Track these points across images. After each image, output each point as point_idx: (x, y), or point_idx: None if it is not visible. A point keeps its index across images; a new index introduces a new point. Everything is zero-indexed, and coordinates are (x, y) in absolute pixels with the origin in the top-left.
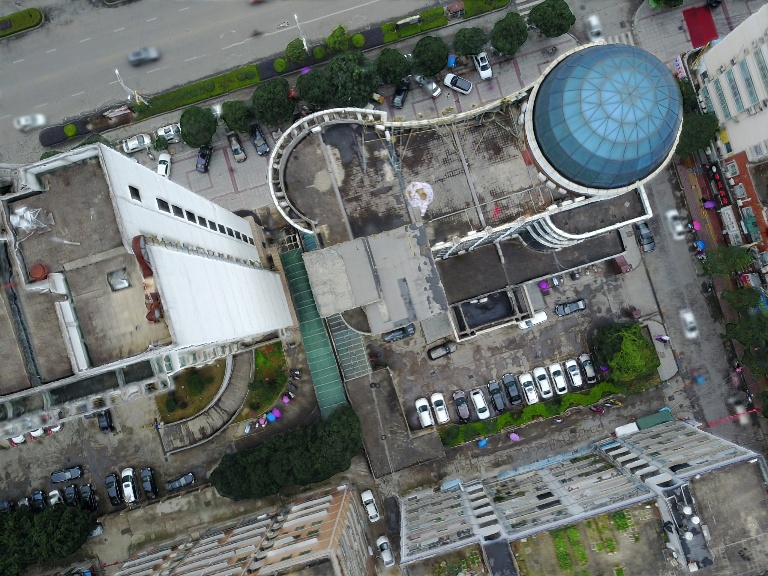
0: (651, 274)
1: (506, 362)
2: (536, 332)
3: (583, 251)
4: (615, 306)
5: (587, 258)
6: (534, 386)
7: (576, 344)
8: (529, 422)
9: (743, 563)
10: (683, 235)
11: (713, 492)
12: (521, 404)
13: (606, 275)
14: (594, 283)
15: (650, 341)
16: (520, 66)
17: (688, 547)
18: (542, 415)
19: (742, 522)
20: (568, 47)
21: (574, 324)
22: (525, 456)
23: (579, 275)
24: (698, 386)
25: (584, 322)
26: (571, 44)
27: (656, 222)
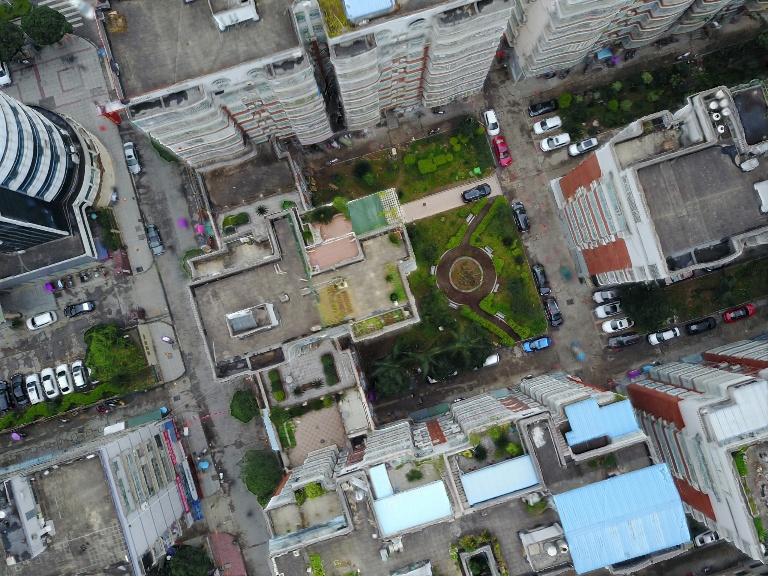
0: (163, 277)
1: (18, 363)
2: (48, 333)
3: (47, 253)
4: (125, 308)
5: (50, 260)
6: (40, 386)
7: (86, 345)
8: (31, 422)
9: (85, 557)
10: (194, 238)
11: (60, 488)
12: (30, 404)
13: (117, 277)
14: (105, 285)
15: (139, 342)
16: (40, 73)
17: (9, 541)
18: (44, 415)
19: (86, 517)
20: (87, 55)
21: (85, 325)
22: (33, 456)
23: (88, 277)
24: (205, 386)
25: (95, 323)
26: (91, 52)
27: (169, 226)
